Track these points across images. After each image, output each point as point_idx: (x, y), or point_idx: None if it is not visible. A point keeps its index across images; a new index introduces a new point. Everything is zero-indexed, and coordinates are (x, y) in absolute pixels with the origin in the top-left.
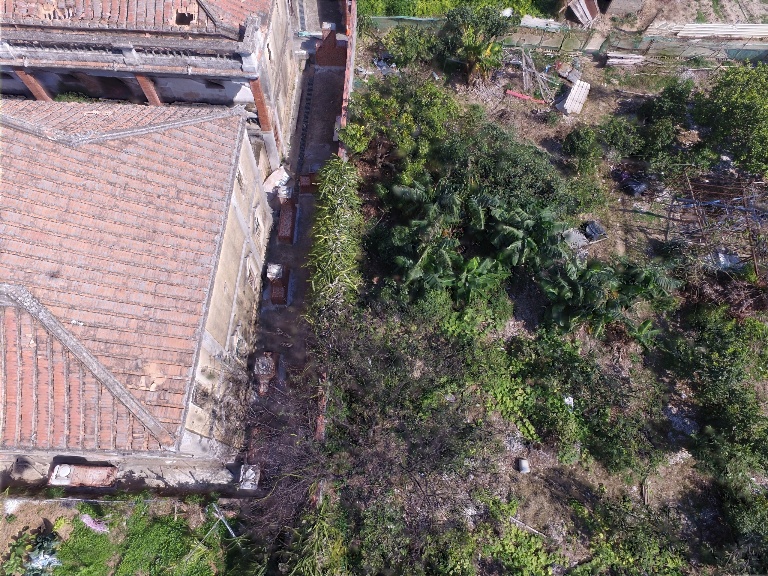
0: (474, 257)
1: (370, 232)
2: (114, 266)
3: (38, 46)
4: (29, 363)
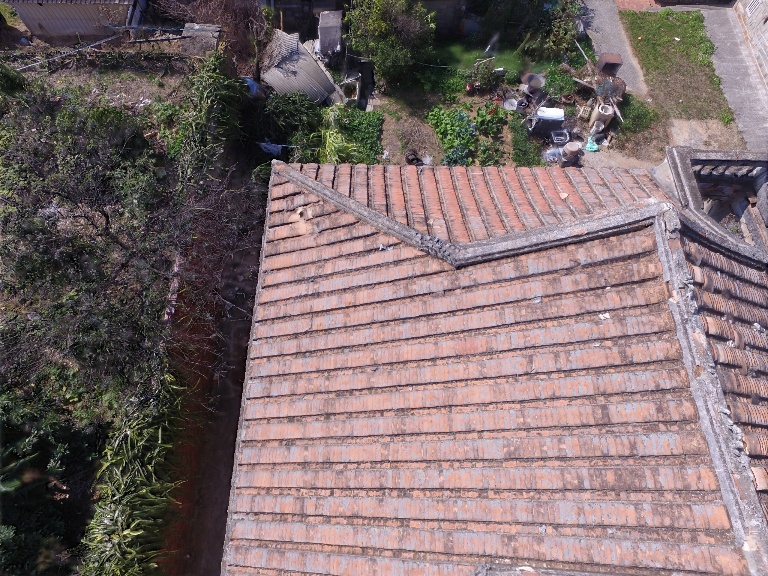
0: None
1: (68, 575)
2: (365, 337)
3: None
4: (433, 210)
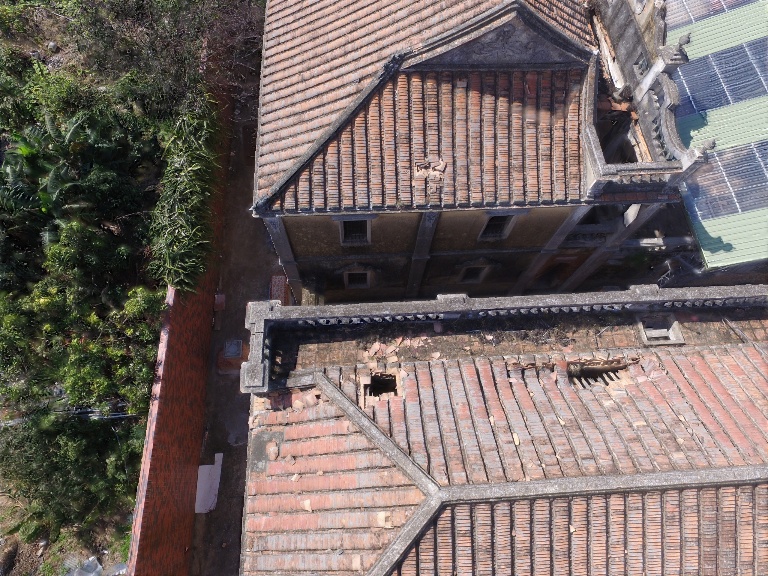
0: (22, 147)
1: None
2: None
3: (593, 318)
4: None
